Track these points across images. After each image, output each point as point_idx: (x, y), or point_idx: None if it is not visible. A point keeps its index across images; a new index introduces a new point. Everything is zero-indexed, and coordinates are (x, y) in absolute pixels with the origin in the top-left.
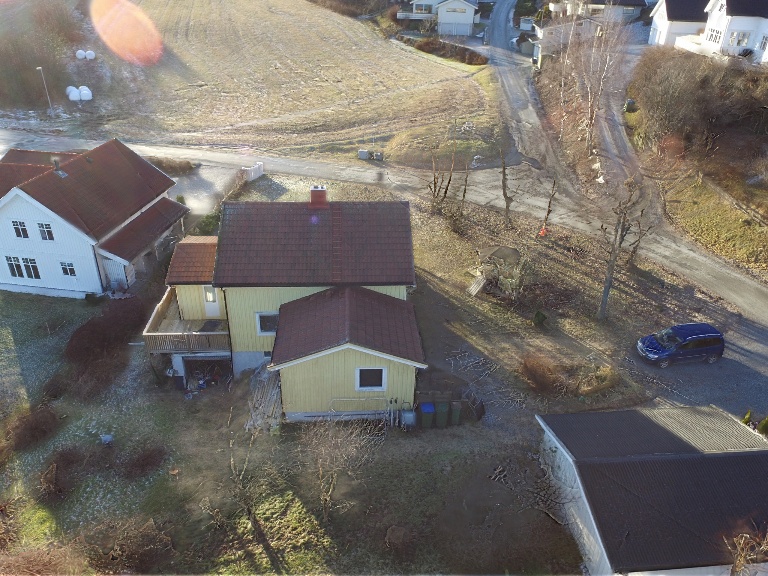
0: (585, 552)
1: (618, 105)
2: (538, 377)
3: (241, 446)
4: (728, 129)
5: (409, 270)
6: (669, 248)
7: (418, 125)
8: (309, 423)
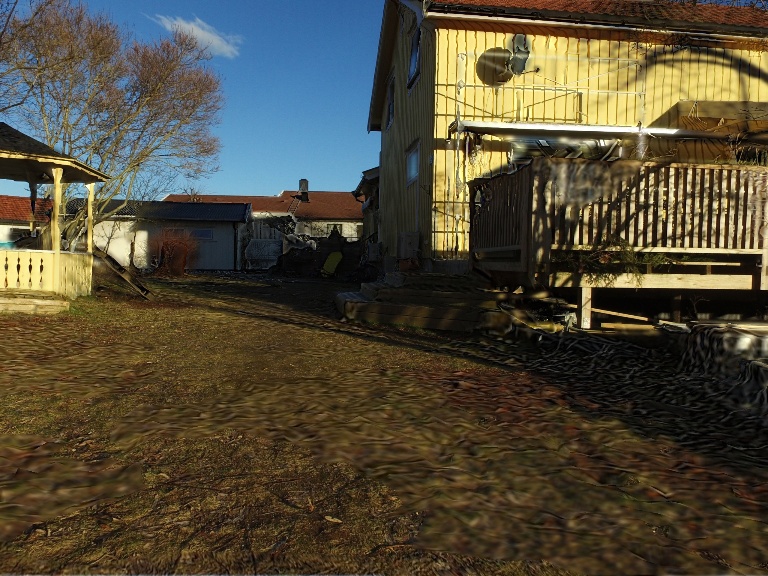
0: None
1: None
2: None
3: None
4: None
5: (380, 109)
6: None
7: None
8: None
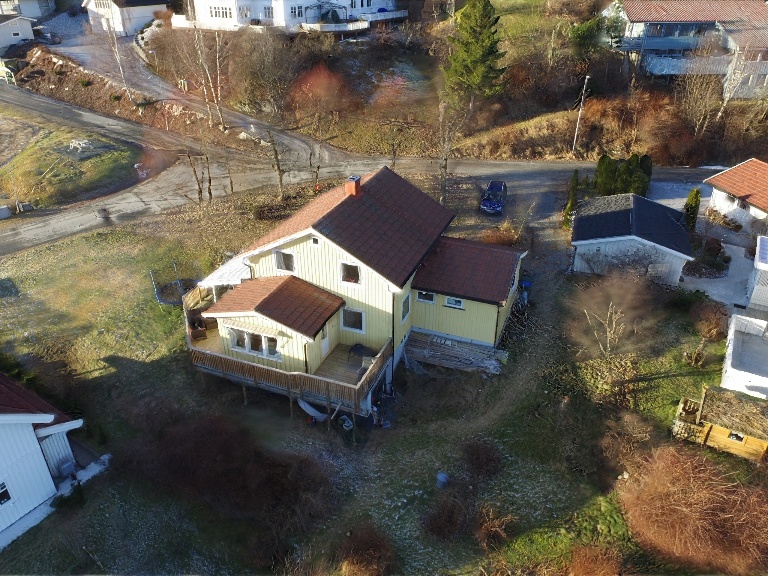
0: (655, 276)
1: (172, 88)
2: (507, 243)
3: (505, 386)
4: (306, 79)
5: (445, 209)
6: (381, 164)
7: (0, 164)
8: (500, 344)
